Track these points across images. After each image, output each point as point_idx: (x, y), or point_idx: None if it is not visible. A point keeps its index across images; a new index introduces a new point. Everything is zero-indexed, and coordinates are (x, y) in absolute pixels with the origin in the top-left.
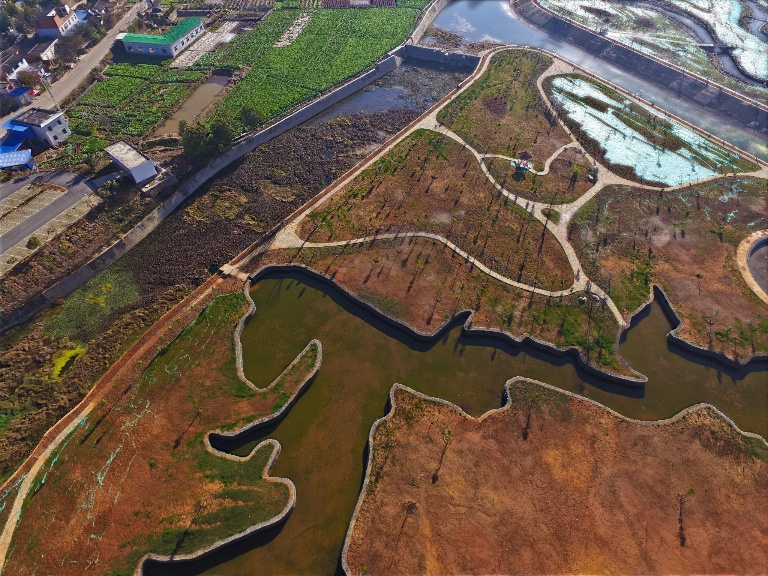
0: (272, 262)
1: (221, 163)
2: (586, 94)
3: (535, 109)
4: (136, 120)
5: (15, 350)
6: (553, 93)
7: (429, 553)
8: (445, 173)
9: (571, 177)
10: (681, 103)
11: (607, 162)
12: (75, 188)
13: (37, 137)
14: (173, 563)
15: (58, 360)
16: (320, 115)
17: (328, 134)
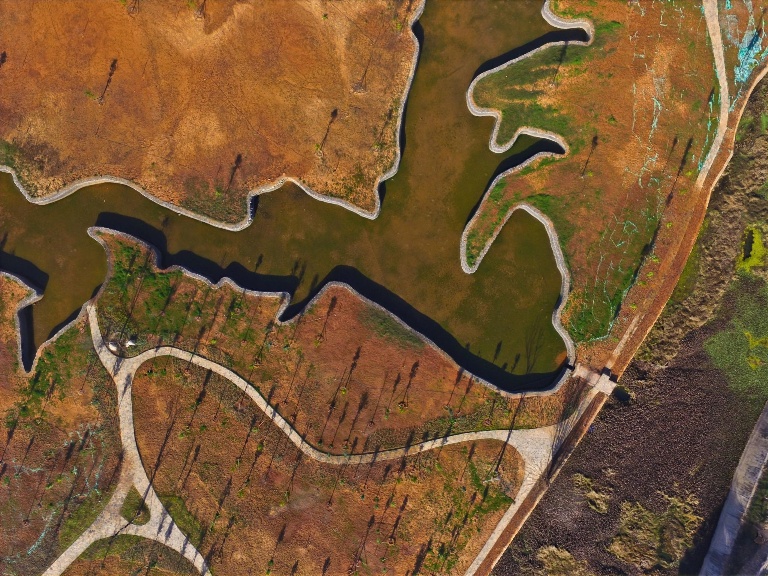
0: (547, 399)
1: None
2: None
3: None
4: None
5: None
6: None
7: (343, 51)
8: None
9: None
10: None
11: None
12: None
13: None
14: None
15: (763, 252)
16: None
17: None
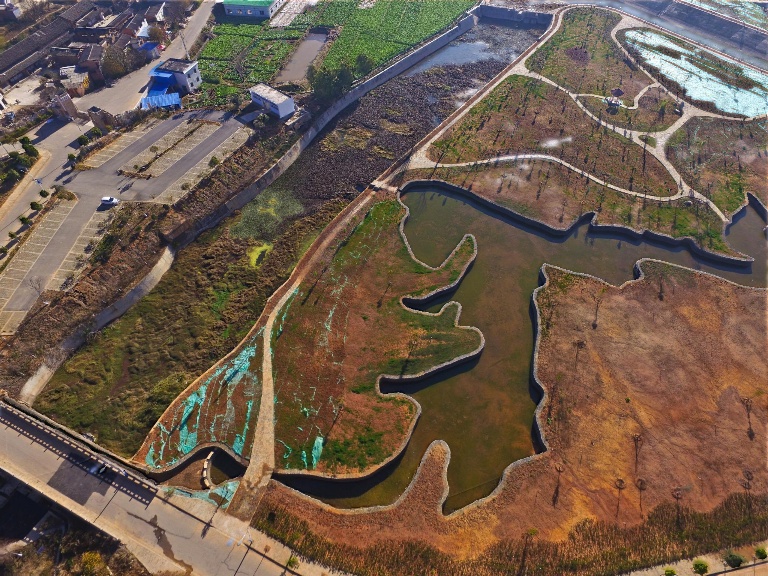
0: (414, 178)
1: (341, 105)
2: (658, 44)
3: (614, 57)
4: (255, 71)
5: (214, 246)
6: (628, 43)
7: (602, 373)
8: (546, 109)
9: (659, 110)
10: (744, 52)
11: (689, 99)
12: (228, 123)
13: (177, 84)
14: (400, 383)
15: (251, 254)
16: (415, 66)
17: (428, 81)
